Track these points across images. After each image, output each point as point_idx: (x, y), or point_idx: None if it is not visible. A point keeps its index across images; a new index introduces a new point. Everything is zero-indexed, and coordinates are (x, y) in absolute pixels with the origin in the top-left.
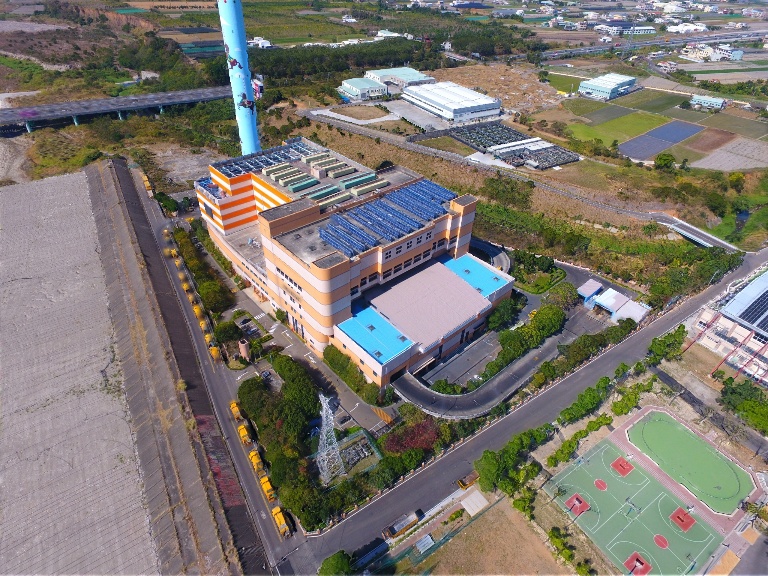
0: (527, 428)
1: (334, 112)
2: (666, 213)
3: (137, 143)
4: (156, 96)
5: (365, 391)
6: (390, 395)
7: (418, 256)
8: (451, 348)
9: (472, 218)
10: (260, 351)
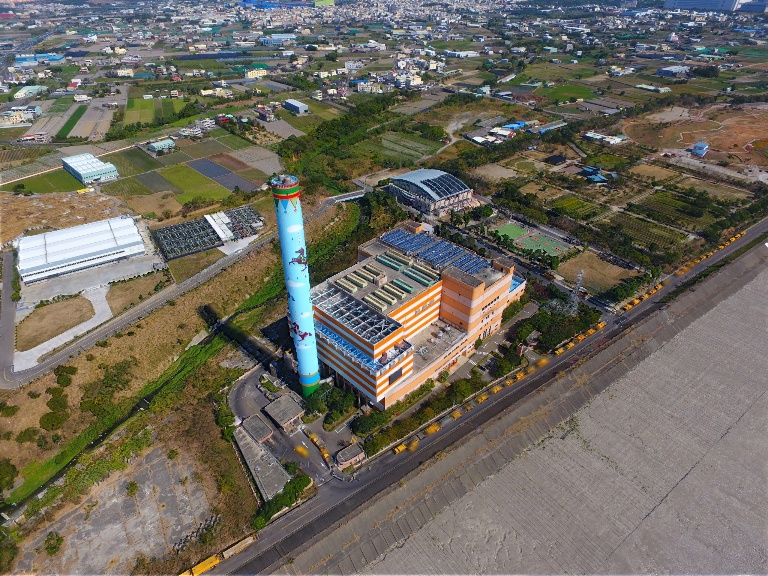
0: None
1: (38, 345)
2: (322, 199)
3: None
4: None
5: None
6: None
7: None
8: None
9: None
10: None
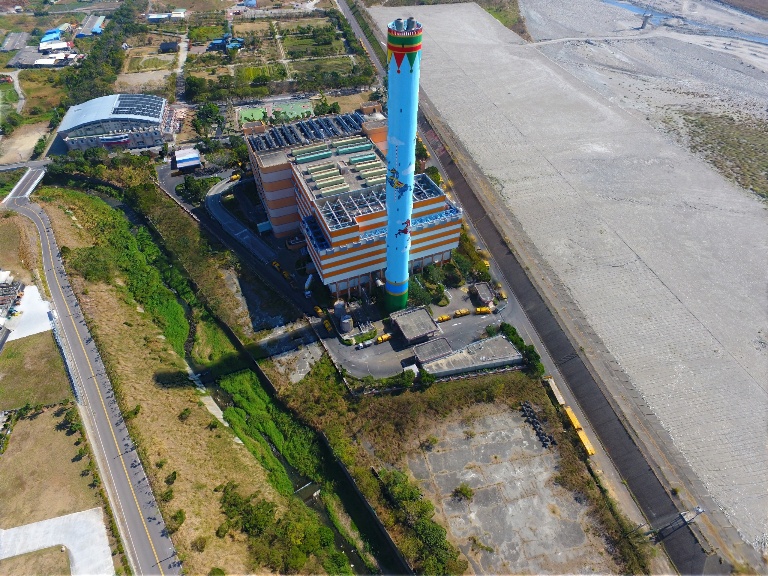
0: None
1: None
2: None
3: None
4: None
5: None
6: None
7: None
8: None
9: None
10: None
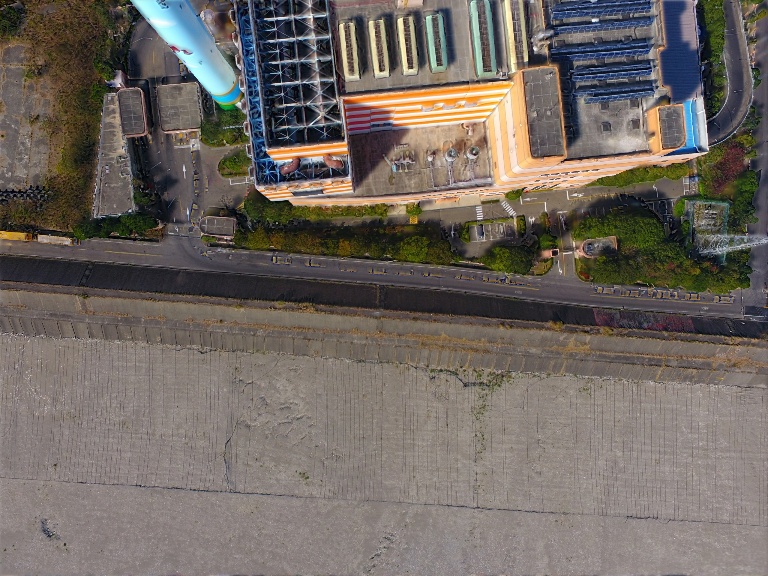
0: None
1: None
2: None
3: None
4: None
5: None
6: None
7: None
8: None
9: None
10: None
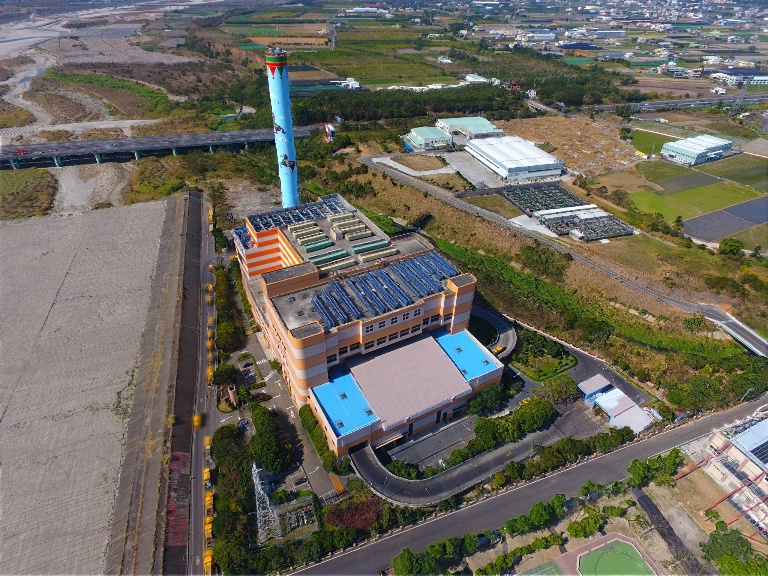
0: (472, 529)
1: (394, 161)
2: (719, 307)
3: (217, 177)
4: (245, 133)
5: (323, 458)
6: (346, 466)
7: (406, 330)
8: (425, 426)
9: (470, 298)
10: (247, 398)
